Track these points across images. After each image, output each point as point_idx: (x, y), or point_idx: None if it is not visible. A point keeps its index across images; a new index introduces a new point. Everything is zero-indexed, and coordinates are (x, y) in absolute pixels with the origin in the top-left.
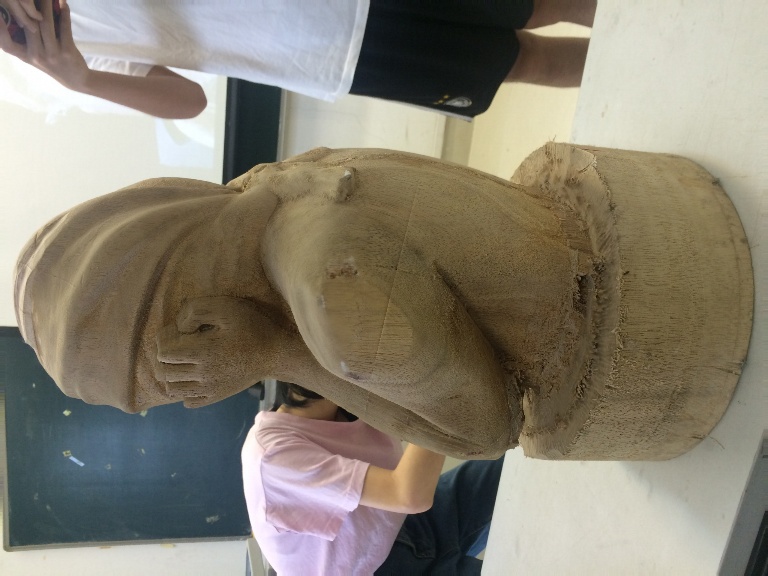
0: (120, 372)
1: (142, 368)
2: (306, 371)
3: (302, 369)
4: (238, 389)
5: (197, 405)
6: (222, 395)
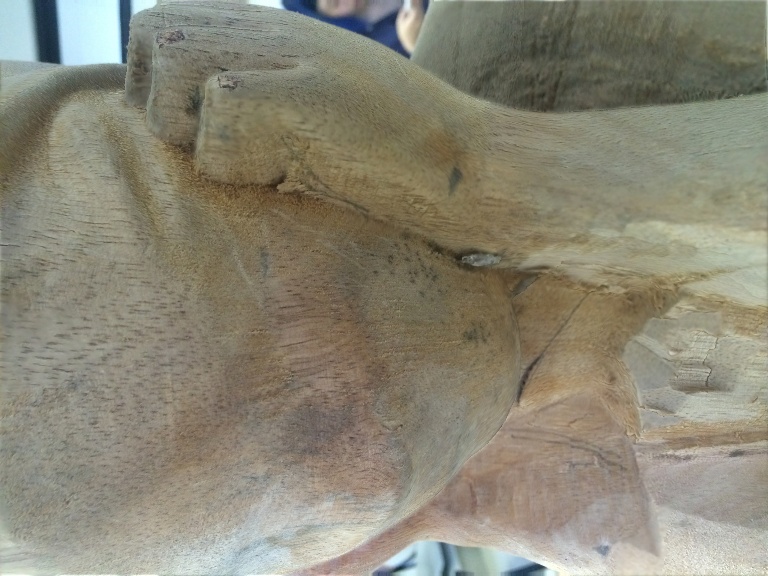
0: (6, 88)
1: (81, 106)
2: (582, 121)
3: (568, 121)
4: (394, 108)
5: (256, 77)
6: (344, 78)
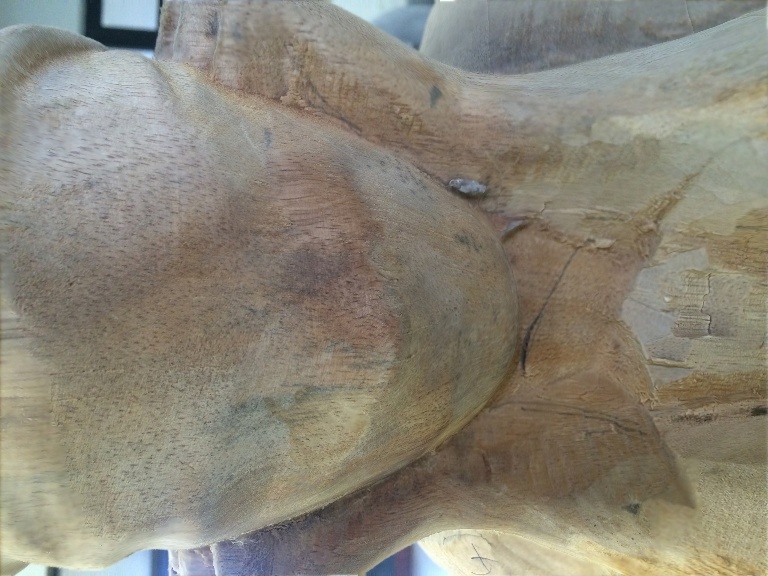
0: None
1: None
2: (543, 72)
3: None
4: (379, 35)
5: None
6: None
